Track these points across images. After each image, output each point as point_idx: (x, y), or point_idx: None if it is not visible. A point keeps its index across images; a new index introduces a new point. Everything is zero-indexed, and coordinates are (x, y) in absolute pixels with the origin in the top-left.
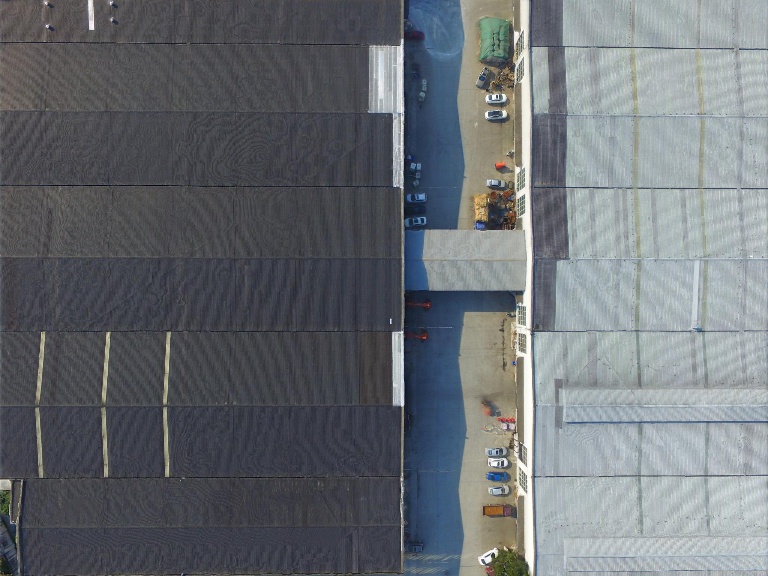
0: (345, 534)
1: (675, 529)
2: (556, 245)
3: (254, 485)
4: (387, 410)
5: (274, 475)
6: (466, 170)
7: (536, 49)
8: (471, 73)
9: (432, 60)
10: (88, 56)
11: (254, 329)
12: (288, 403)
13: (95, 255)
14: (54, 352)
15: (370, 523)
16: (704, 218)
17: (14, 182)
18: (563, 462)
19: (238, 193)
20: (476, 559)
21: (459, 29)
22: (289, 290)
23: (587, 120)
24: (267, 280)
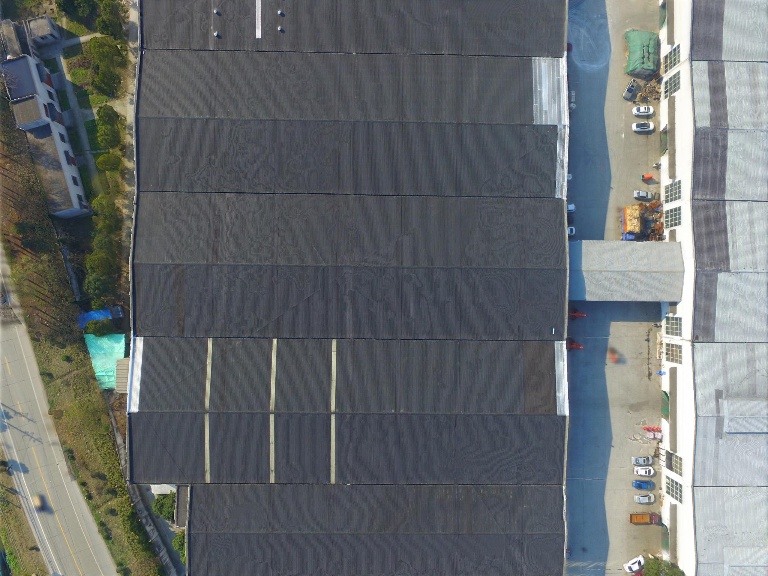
0: (509, 541)
1: None
2: (717, 257)
3: (418, 492)
4: (551, 419)
5: (438, 482)
6: (613, 181)
7: (696, 63)
8: (618, 85)
9: (579, 71)
10: (255, 64)
11: (418, 337)
12: (454, 411)
13: (264, 262)
14: (222, 358)
15: (534, 531)
16: None
17: (181, 189)
18: (722, 472)
19: (403, 202)
20: (621, 566)
21: (606, 41)
22: (454, 299)
23: (748, 134)
24: (433, 289)
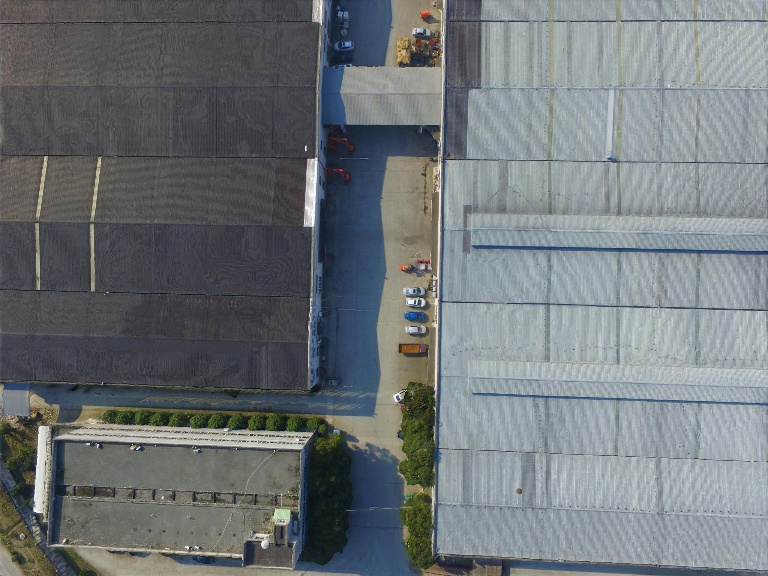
0: (255, 349)
1: (583, 357)
2: (468, 75)
3: (172, 301)
4: (298, 231)
5: (191, 292)
6: (393, 21)
7: None
8: None
9: None
10: None
11: (178, 155)
12: (205, 222)
13: (36, 84)
14: None
15: (278, 339)
16: (621, 49)
17: None
18: (471, 287)
19: (168, 29)
20: (392, 397)
21: None
22: (211, 117)
23: None
24: (190, 107)
